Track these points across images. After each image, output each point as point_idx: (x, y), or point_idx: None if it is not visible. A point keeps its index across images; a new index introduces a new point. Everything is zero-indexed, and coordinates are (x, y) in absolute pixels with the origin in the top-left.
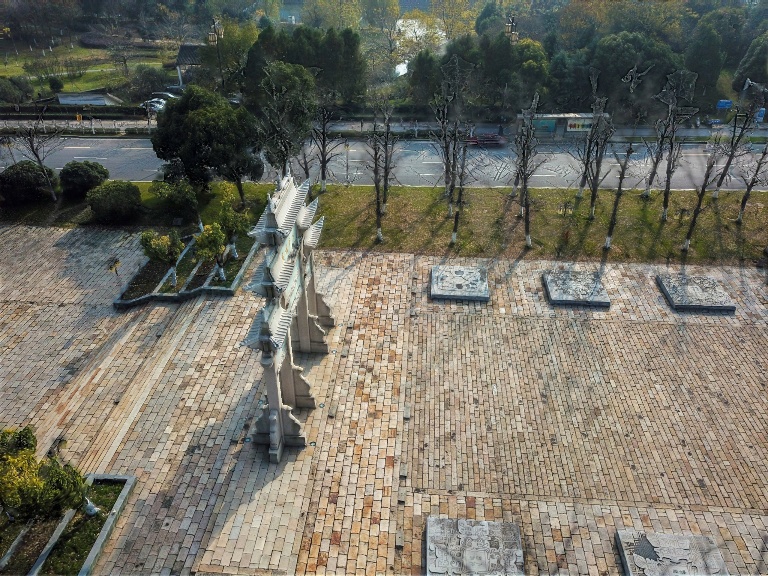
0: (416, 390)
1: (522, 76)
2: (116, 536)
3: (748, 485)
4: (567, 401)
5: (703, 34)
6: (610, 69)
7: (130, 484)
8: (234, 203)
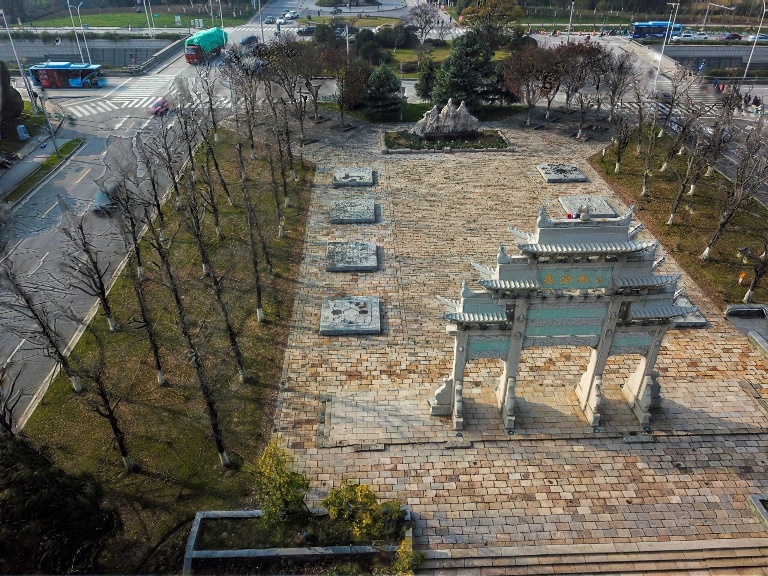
0: None
1: None
2: None
3: None
4: None
5: None
6: None
7: (761, 495)
8: None
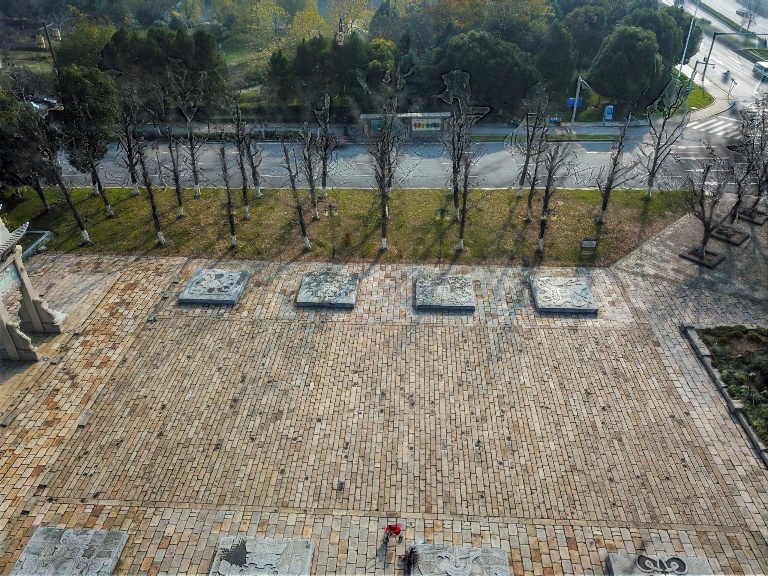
0: (109, 397)
1: (369, 76)
2: None
3: (386, 487)
4: (255, 405)
5: (554, 32)
6: (456, 68)
7: None
8: (40, 208)
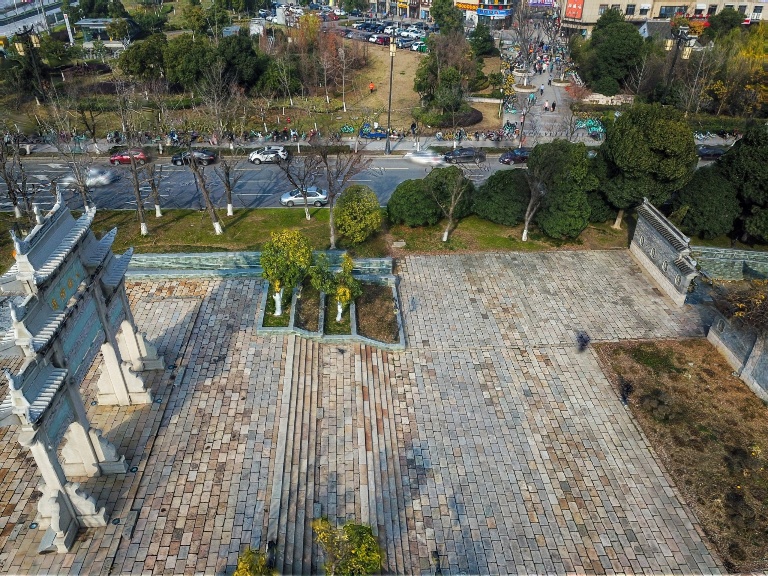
0: None
1: None
2: (258, 309)
3: None
4: None
5: None
6: None
7: (258, 325)
8: None
